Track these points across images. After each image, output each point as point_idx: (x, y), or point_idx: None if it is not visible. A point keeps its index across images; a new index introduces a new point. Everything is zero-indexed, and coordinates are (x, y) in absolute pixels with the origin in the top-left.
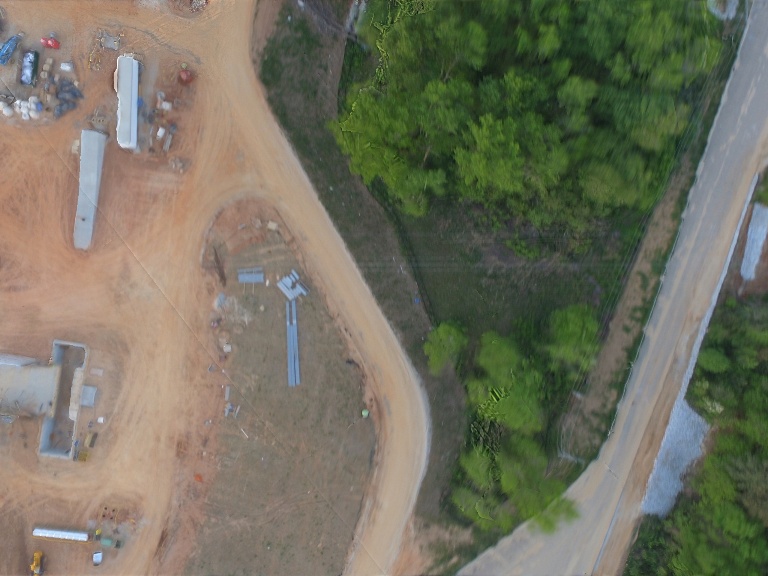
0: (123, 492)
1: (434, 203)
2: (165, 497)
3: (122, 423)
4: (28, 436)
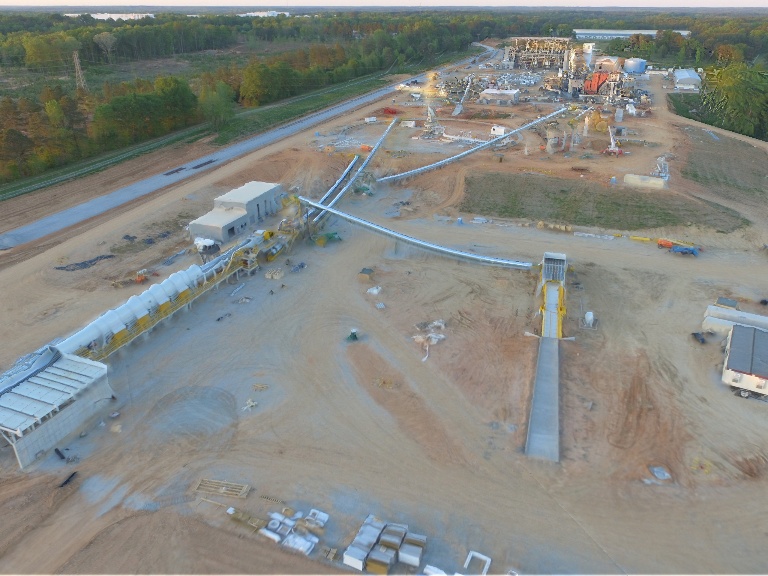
0: (652, 141)
1: (756, 132)
2: (672, 142)
3: (646, 134)
4: (606, 133)
